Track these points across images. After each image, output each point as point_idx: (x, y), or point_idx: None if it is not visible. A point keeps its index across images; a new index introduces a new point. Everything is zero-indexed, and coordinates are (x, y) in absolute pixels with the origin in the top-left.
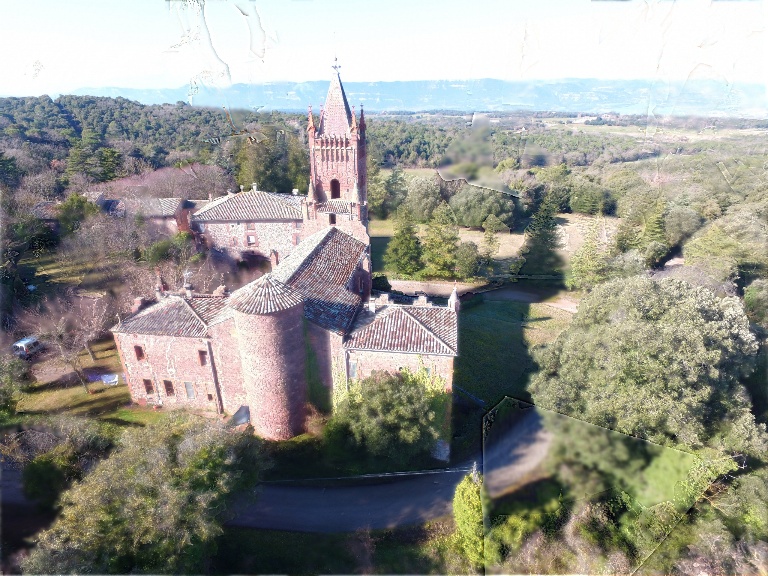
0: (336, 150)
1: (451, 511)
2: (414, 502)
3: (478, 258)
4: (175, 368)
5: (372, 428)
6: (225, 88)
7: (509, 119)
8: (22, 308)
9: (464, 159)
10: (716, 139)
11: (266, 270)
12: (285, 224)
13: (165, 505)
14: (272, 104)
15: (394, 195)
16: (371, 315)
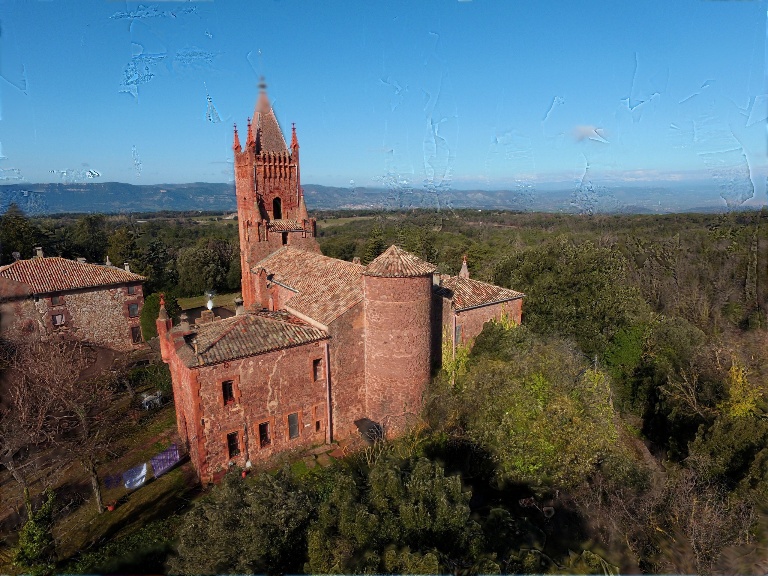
0: (279, 166)
1: None
2: None
3: None
4: (278, 398)
5: None
6: None
7: None
8: None
9: (565, 119)
10: None
11: None
12: (112, 291)
13: None
14: None
15: (159, 270)
16: (438, 288)
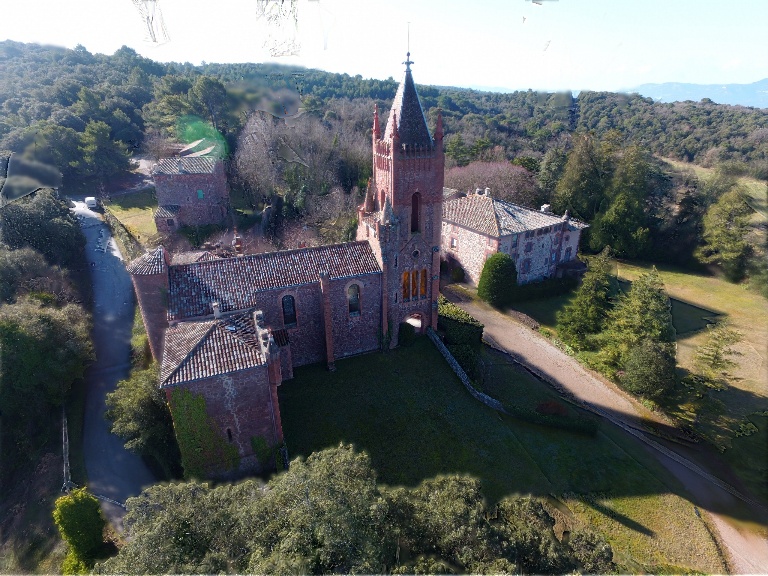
0: (383, 158)
1: (114, 522)
2: (124, 491)
3: (659, 375)
4: None
5: None
6: (244, 89)
7: None
8: (267, 236)
9: None
10: None
11: (454, 277)
12: (481, 236)
13: None
14: None
15: (766, 252)
16: None
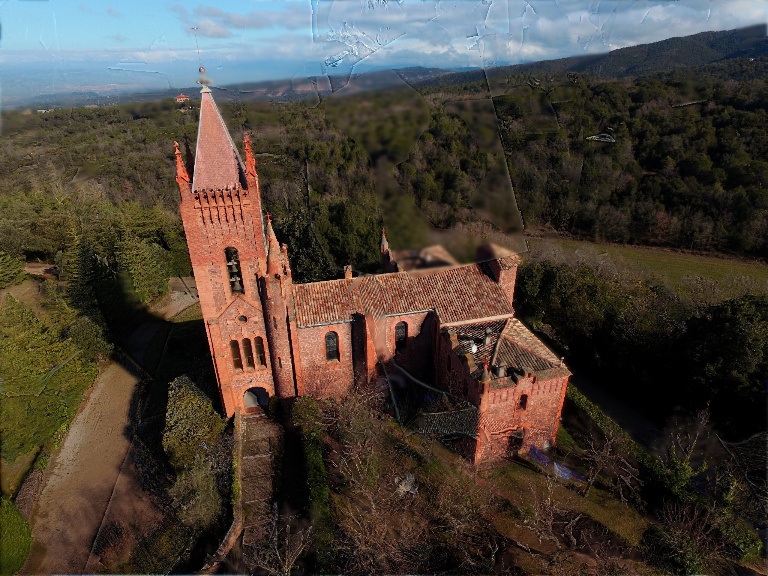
0: None
1: None
2: None
3: None
4: None
5: None
6: None
7: None
8: None
9: None
10: None
11: None
12: None
13: None
14: None
15: None
16: None
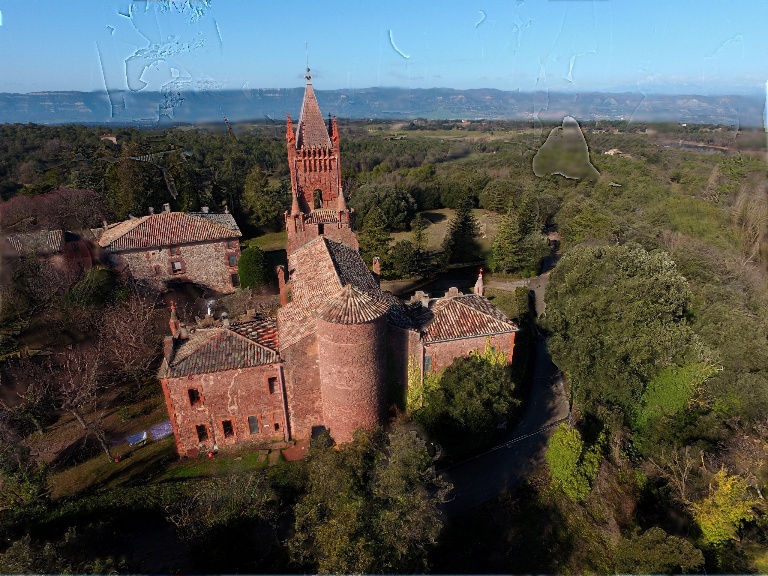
0: (319, 160)
1: (538, 465)
2: (506, 467)
3: (414, 254)
4: (238, 404)
5: (477, 408)
6: (249, 99)
7: (389, 126)
8: None
9: (560, 157)
10: None
11: None
12: (215, 244)
13: (414, 510)
14: (269, 115)
15: (287, 206)
16: (426, 310)
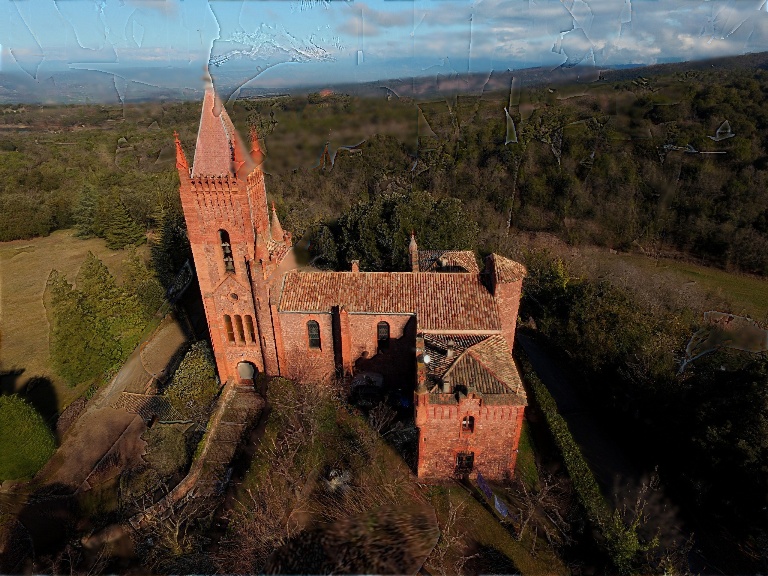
0: None
1: None
2: None
3: None
4: None
5: None
6: (389, 113)
7: None
8: None
9: None
10: (87, 131)
11: None
12: None
13: None
14: None
15: None
16: (447, 268)
